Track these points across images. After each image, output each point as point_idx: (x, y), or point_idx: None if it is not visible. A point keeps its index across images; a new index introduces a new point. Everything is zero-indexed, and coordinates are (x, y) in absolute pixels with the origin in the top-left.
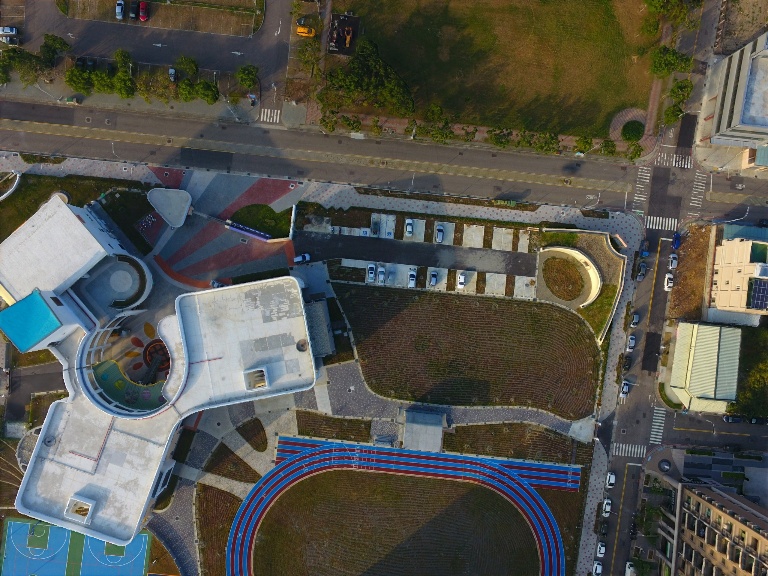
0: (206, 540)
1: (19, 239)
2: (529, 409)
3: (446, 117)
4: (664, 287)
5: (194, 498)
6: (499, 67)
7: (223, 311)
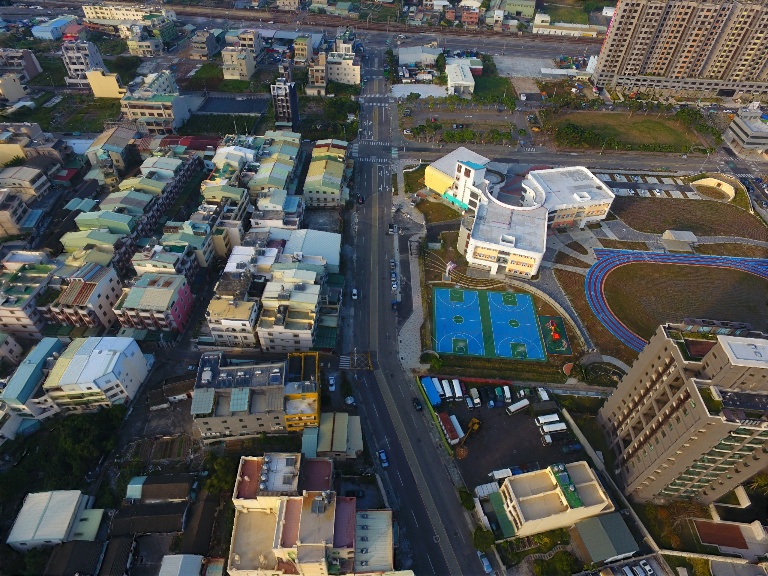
0: (571, 295)
1: (447, 158)
2: (735, 238)
3: (612, 149)
4: (767, 194)
5: (554, 275)
6: (627, 137)
7: (552, 178)
